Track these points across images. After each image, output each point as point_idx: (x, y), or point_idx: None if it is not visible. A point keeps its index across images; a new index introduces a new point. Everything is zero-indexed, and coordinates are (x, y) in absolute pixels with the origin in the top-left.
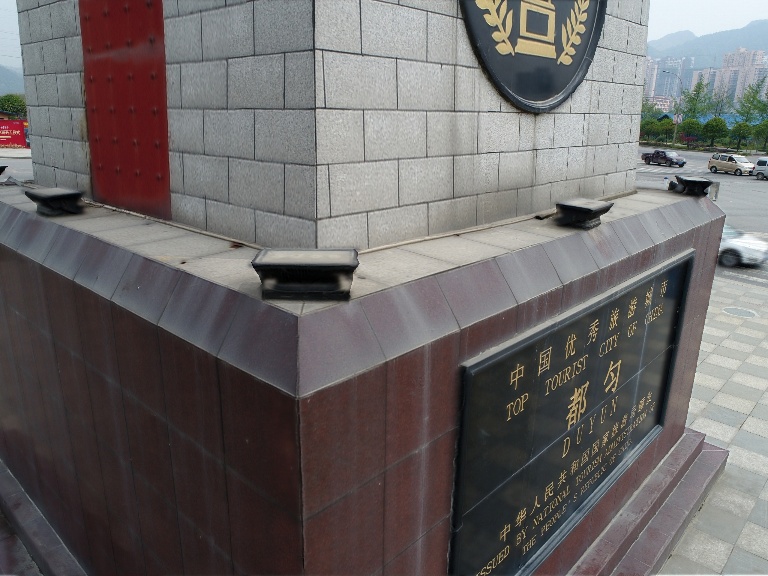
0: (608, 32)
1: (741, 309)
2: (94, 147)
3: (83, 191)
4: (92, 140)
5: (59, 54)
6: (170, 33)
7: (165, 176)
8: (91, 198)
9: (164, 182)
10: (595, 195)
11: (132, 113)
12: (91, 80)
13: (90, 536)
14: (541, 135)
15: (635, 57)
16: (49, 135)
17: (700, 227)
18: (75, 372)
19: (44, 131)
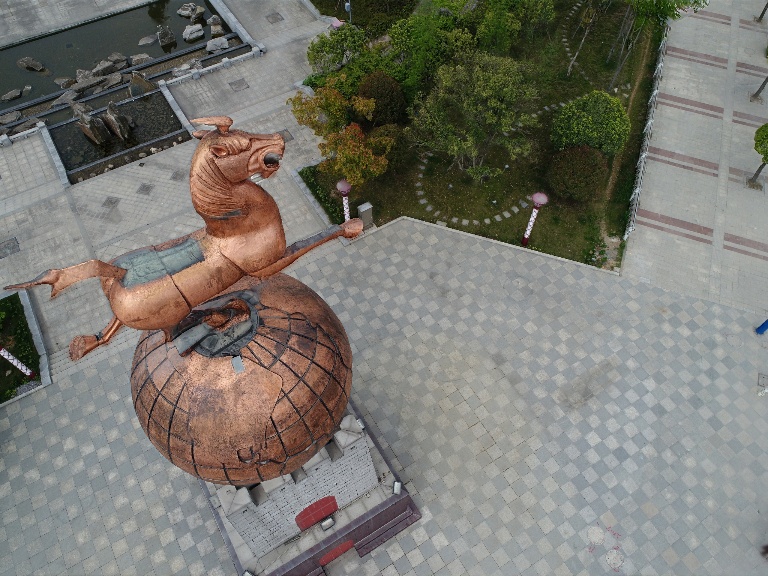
0: None
1: None
2: None
3: None
4: None
5: None
6: None
7: None
8: None
9: None
10: None
11: None
12: None
13: None
14: None
15: None
16: None
17: None
18: None
19: None
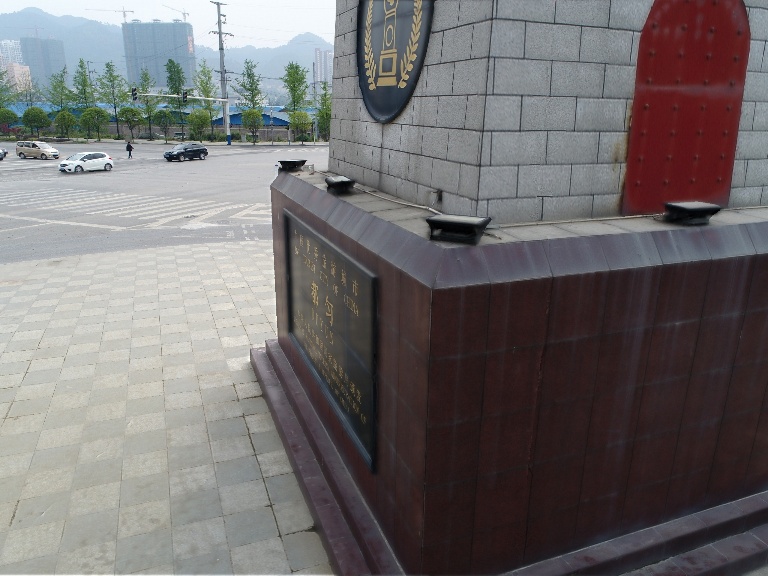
0: None
1: None
2: (634, 167)
3: (603, 211)
4: (633, 160)
5: (590, 78)
6: (751, 81)
7: (727, 178)
8: (619, 215)
9: (725, 182)
10: None
11: (699, 135)
12: (646, 107)
13: (717, 465)
14: None
15: None
16: (542, 162)
17: None
18: (767, 322)
19: (529, 159)
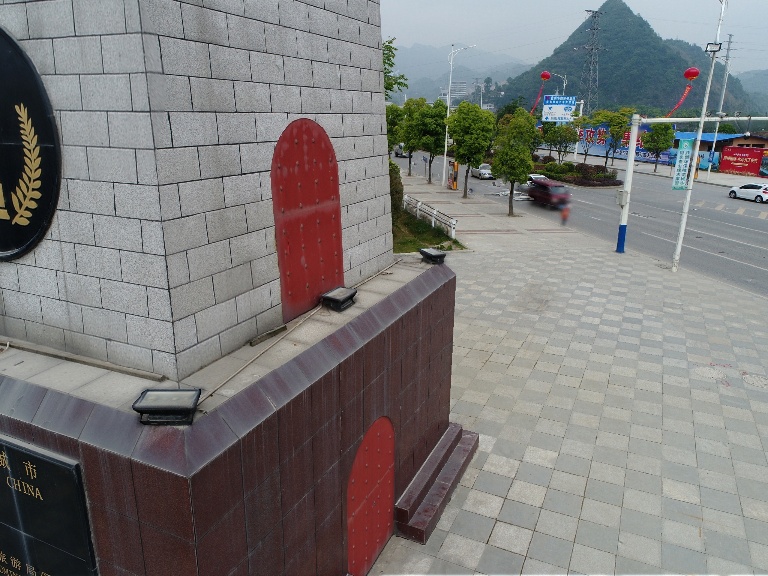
0: (77, 196)
1: None
2: None
3: None
4: None
5: None
6: None
7: None
8: None
9: None
10: (93, 354)
11: None
12: None
13: None
14: (5, 278)
15: (137, 221)
16: None
17: (94, 447)
18: None
19: None
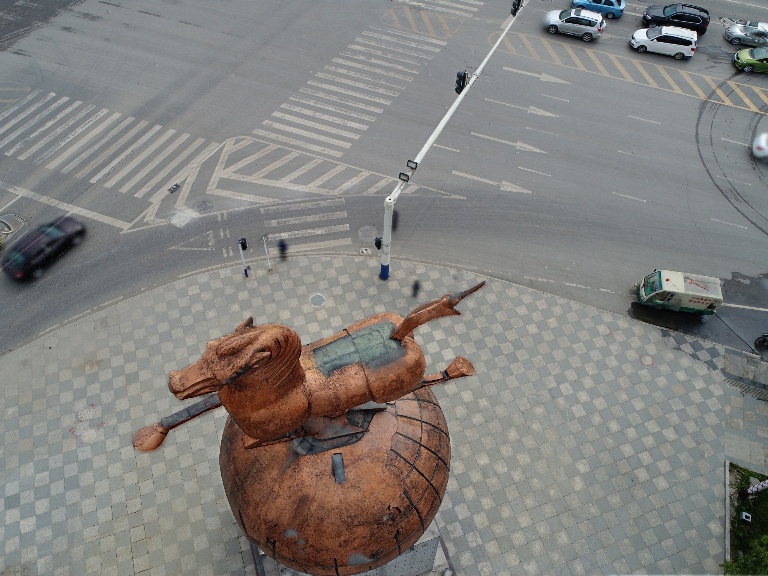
0: None
1: (315, 296)
2: None
3: None
4: None
5: None
6: None
7: None
8: None
9: None
10: None
11: None
12: None
13: None
14: None
15: None
16: None
17: None
18: None
19: None
